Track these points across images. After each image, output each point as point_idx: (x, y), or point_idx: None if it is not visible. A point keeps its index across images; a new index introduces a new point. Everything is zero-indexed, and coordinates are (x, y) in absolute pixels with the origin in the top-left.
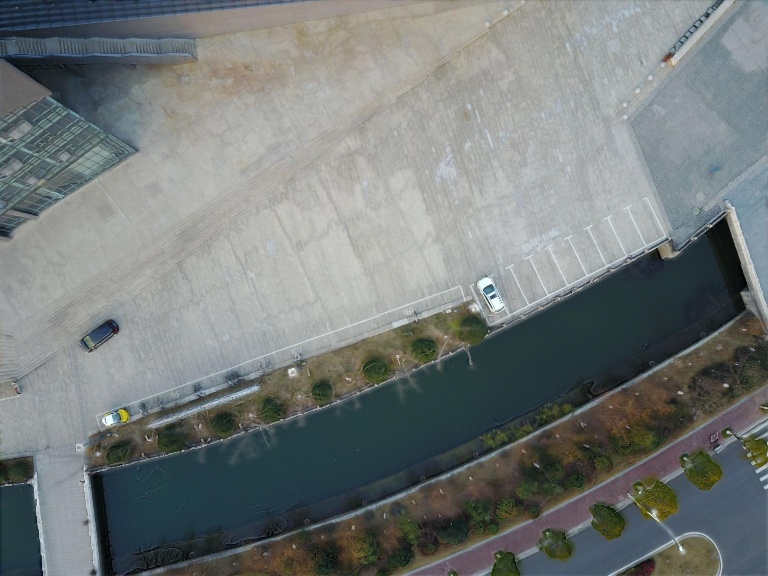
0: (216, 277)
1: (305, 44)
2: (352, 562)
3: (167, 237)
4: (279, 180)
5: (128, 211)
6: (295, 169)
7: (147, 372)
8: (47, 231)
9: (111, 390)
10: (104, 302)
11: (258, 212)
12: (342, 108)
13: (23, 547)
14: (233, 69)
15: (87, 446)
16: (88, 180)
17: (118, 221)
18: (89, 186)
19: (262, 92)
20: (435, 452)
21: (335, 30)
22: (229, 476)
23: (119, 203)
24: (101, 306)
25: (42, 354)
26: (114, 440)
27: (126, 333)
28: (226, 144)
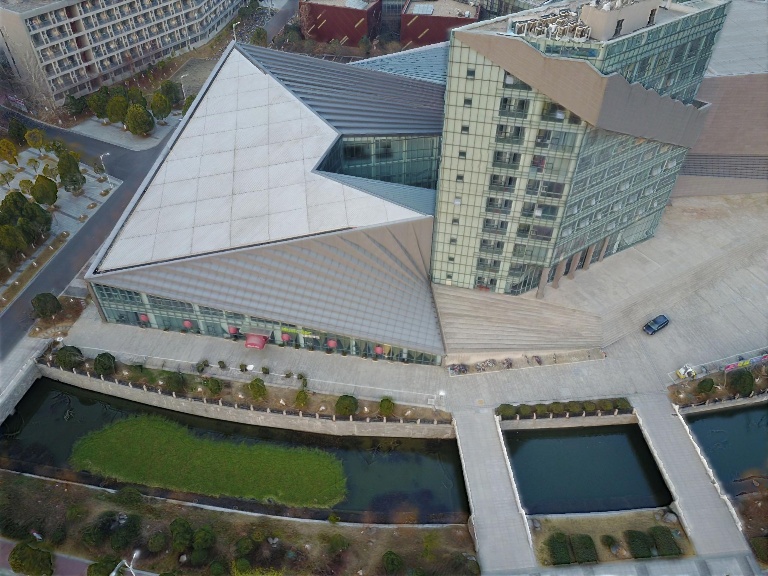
0: (724, 299)
1: (731, 203)
2: None
3: (687, 274)
4: (744, 255)
5: (658, 261)
6: (751, 251)
7: (697, 349)
8: (609, 267)
9: (674, 358)
10: (653, 307)
11: (737, 270)
12: (767, 226)
13: (620, 482)
14: (694, 210)
15: (668, 393)
16: (628, 246)
17: (653, 265)
18: (629, 249)
19: (716, 218)
20: None
21: (745, 198)
22: (762, 460)
23: (650, 257)
24: (651, 309)
25: (616, 334)
26: (689, 389)
27: (672, 326)
28: (705, 237)
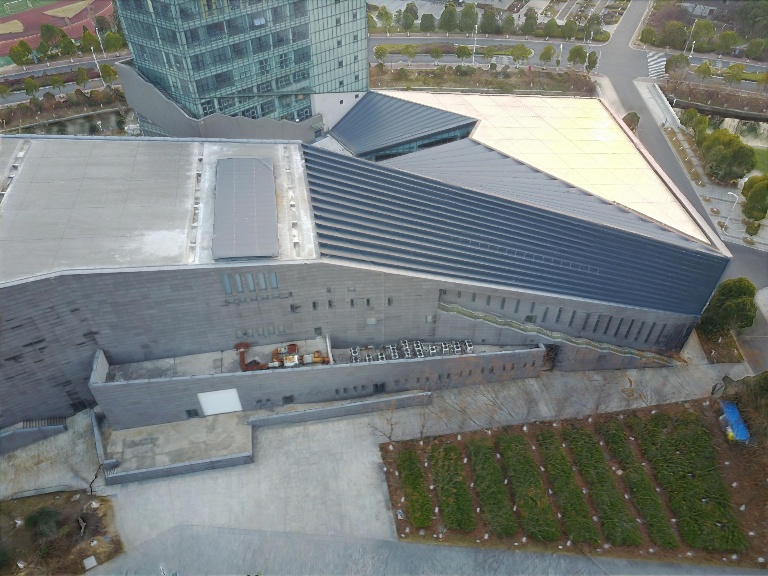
0: None
1: None
2: (102, 92)
3: None
4: None
5: None
6: None
7: None
8: None
9: None
10: None
11: None
12: None
13: None
14: None
15: None
16: None
17: None
18: None
19: None
20: (52, 129)
21: None
22: None
23: None
24: None
25: None
26: None
27: None
28: None
